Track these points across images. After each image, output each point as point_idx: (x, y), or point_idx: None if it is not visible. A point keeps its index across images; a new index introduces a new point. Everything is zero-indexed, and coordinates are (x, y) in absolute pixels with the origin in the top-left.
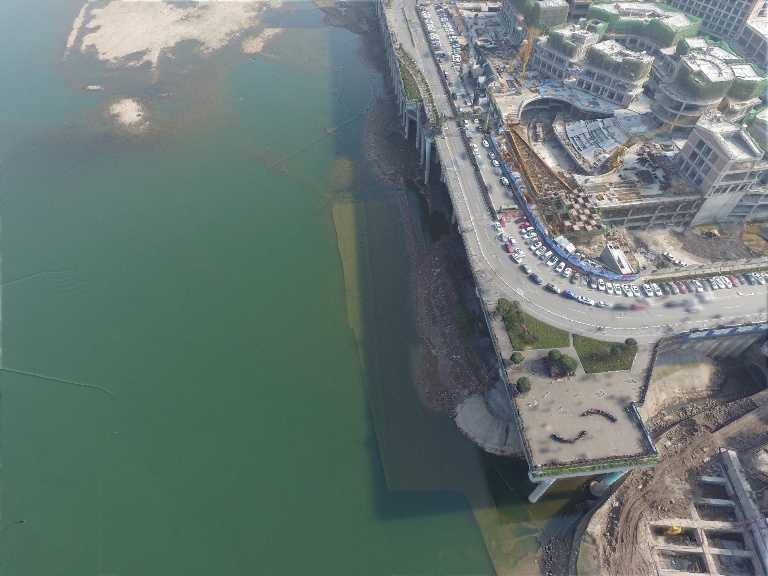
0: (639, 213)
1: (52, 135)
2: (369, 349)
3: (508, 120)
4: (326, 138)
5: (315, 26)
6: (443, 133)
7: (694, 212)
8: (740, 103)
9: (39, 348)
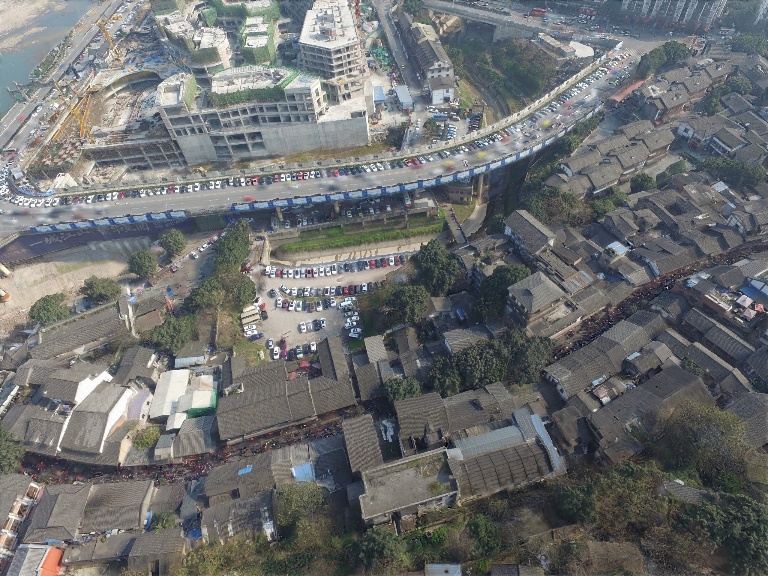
0: (129, 154)
1: None
2: None
3: (92, 89)
4: (4, 113)
5: None
6: (28, 100)
7: (181, 153)
8: None
9: None
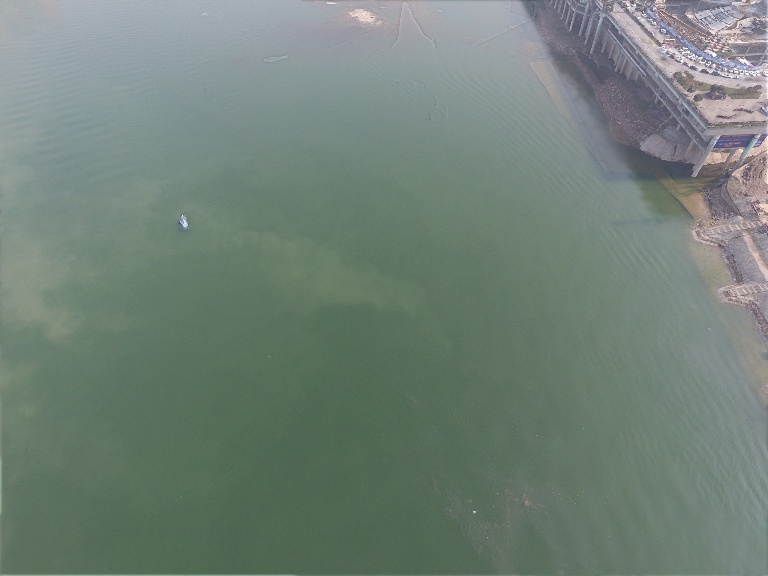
0: (754, 51)
1: (318, 26)
2: (577, 122)
3: (656, 6)
4: (511, 31)
5: None
6: (613, 11)
7: None
8: None
9: (433, 70)
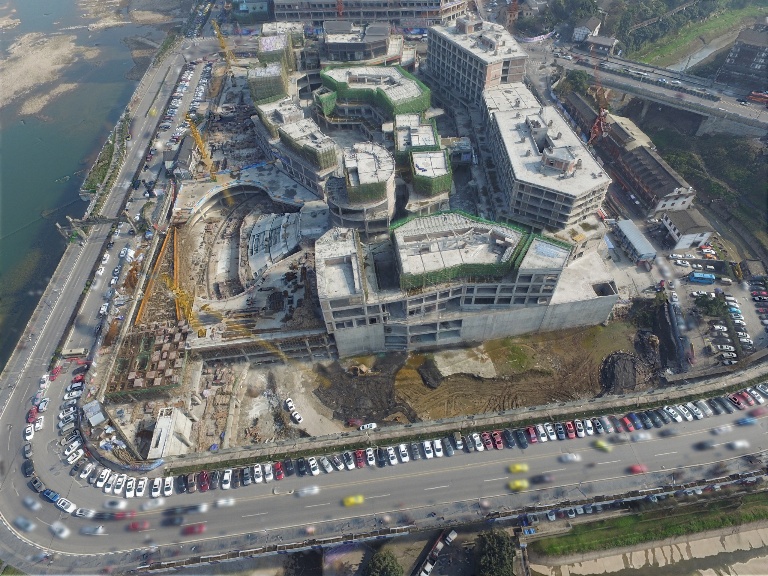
0: (257, 350)
1: None
2: None
3: (176, 217)
4: (37, 223)
5: (115, 80)
6: (86, 237)
7: (333, 345)
8: (420, 202)
9: None
